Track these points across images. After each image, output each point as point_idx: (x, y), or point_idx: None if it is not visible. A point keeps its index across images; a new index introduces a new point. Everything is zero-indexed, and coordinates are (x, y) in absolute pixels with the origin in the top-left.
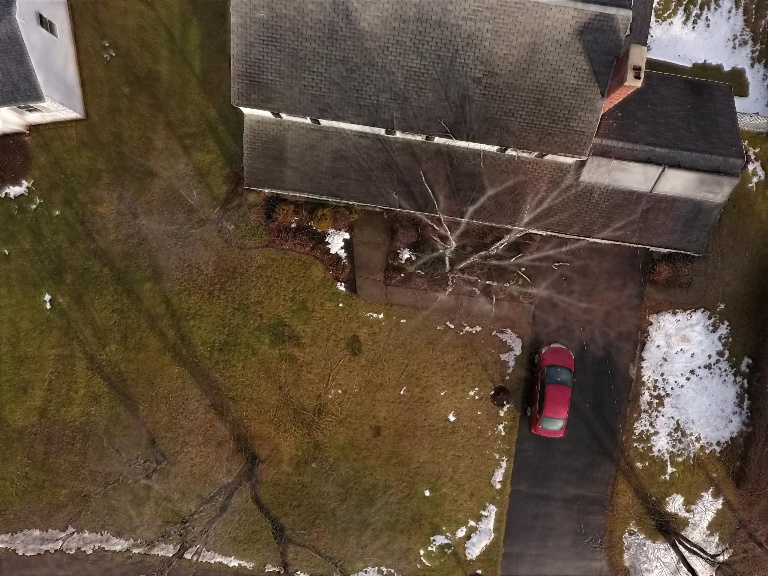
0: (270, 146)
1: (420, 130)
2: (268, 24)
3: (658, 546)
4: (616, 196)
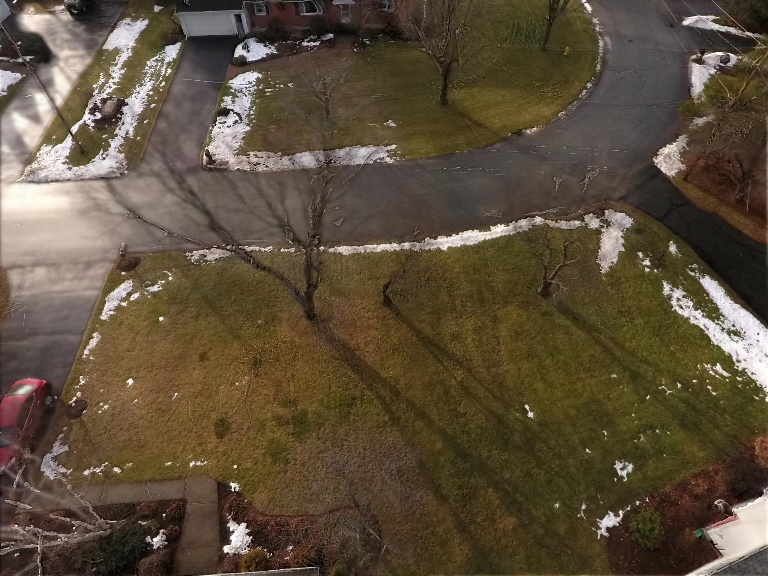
0: None
1: None
2: None
3: None
4: None
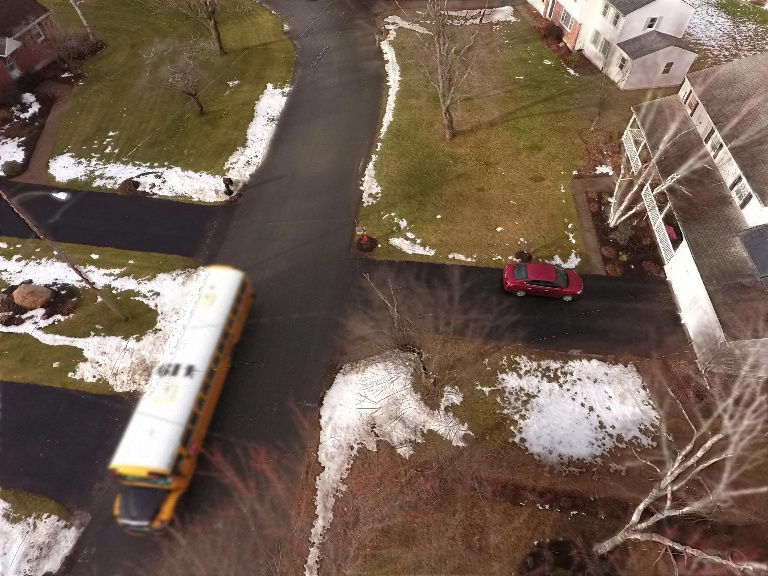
0: (664, 107)
1: (723, 134)
2: (741, 71)
3: (409, 379)
4: (741, 261)
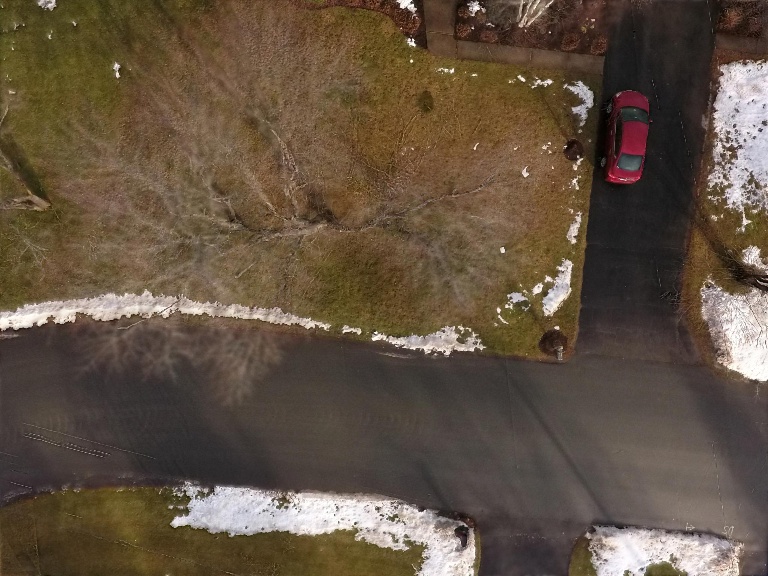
0: None
1: None
2: None
3: (736, 297)
4: None
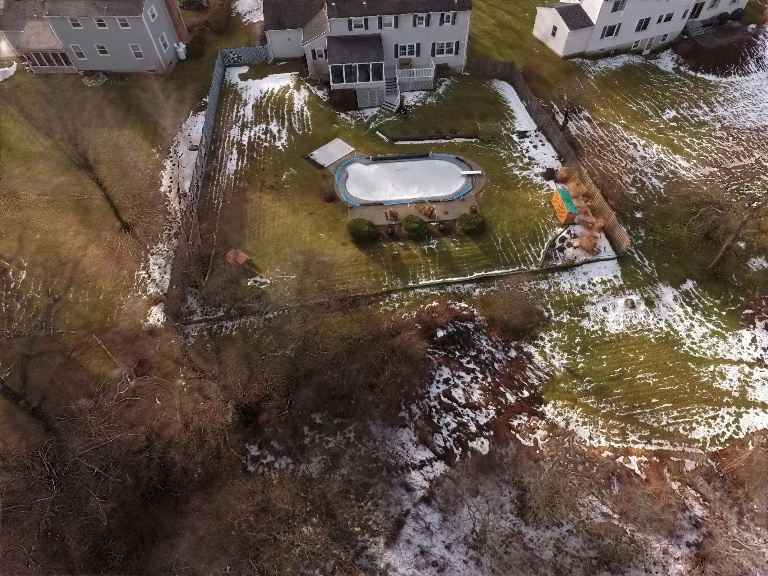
0: None
1: None
2: None
3: None
4: None
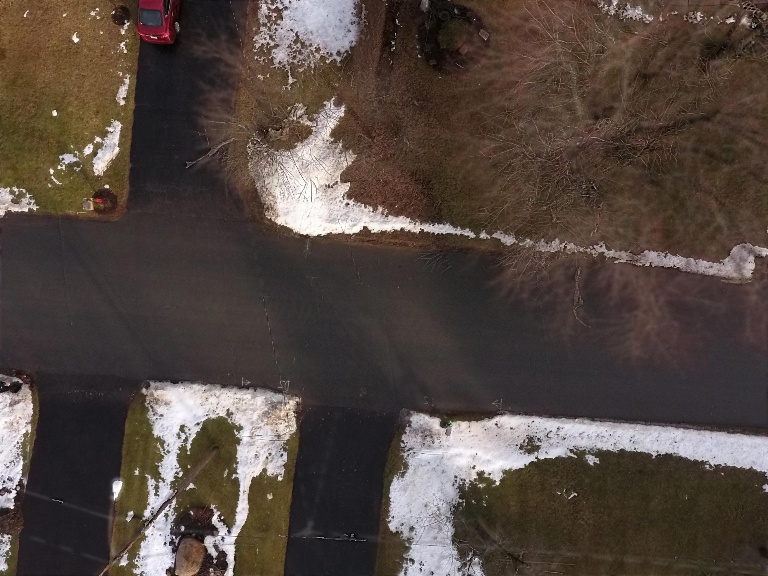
0: None
1: None
2: None
3: (281, 153)
4: None
